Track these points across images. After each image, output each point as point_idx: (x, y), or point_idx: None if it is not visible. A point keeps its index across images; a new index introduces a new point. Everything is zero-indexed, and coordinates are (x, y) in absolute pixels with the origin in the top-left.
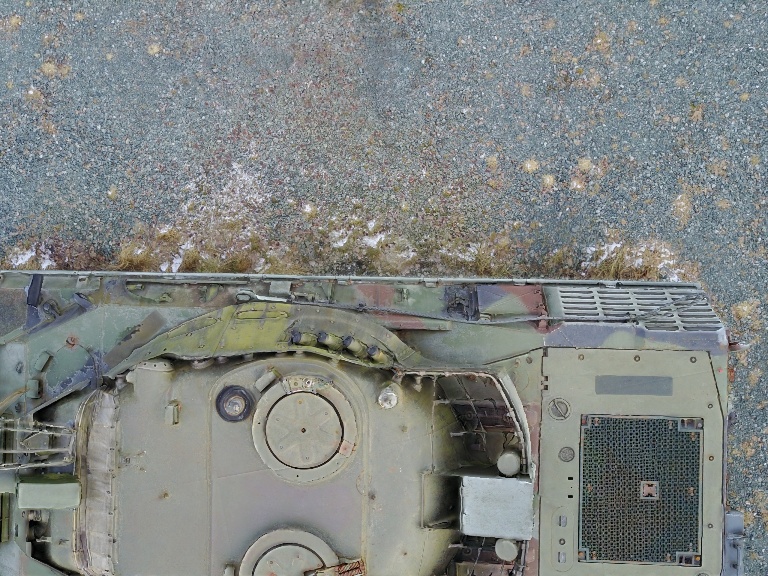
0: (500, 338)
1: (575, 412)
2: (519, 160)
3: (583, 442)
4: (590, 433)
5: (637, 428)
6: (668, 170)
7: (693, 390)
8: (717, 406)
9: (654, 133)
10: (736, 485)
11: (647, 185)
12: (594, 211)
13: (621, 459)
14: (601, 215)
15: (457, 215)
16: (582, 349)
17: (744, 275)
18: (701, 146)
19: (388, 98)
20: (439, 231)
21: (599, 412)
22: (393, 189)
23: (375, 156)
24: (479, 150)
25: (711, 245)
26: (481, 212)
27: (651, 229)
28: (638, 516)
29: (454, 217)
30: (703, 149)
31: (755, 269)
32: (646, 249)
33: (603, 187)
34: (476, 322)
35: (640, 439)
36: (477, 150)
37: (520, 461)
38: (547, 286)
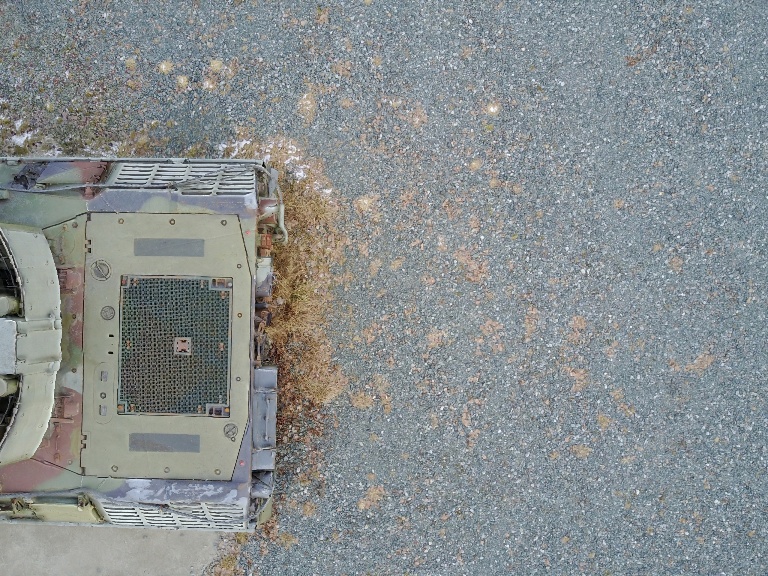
0: (51, 205)
1: (115, 273)
2: (156, 62)
3: (122, 301)
4: (129, 293)
5: (172, 287)
6: (295, 70)
7: (223, 251)
8: (246, 266)
9: (282, 35)
10: (357, 370)
11: (275, 85)
12: (225, 110)
13: (157, 317)
14: (232, 114)
15: (99, 115)
16: (122, 213)
17: (366, 170)
18: (327, 48)
19: (33, 3)
20: (83, 131)
21: (138, 273)
22: (38, 90)
23: (21, 59)
24: (119, 53)
25: (335, 141)
26: (122, 112)
27: (279, 127)
28: (172, 370)
29: (97, 117)
30: (328, 50)
31: (376, 164)
32: (274, 146)
33: (234, 87)
34: (29, 190)
35: (175, 298)
36: (117, 53)
37: (17, 305)
38: (119, 163)
